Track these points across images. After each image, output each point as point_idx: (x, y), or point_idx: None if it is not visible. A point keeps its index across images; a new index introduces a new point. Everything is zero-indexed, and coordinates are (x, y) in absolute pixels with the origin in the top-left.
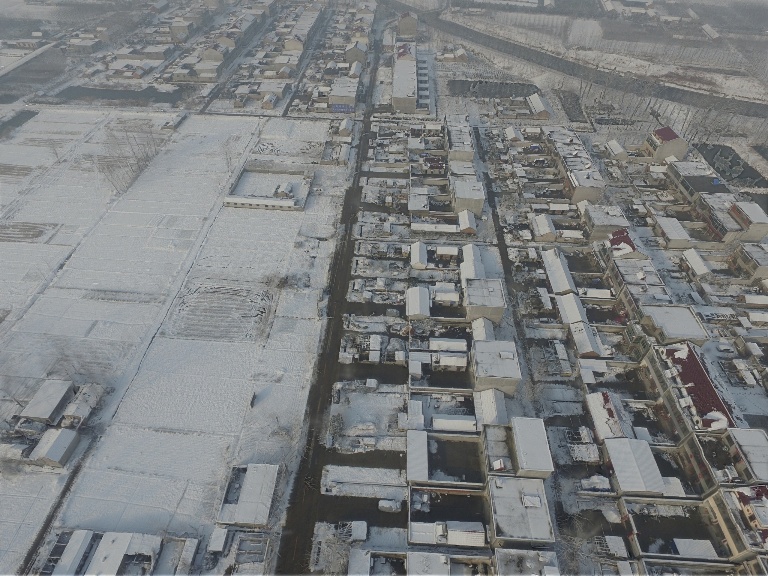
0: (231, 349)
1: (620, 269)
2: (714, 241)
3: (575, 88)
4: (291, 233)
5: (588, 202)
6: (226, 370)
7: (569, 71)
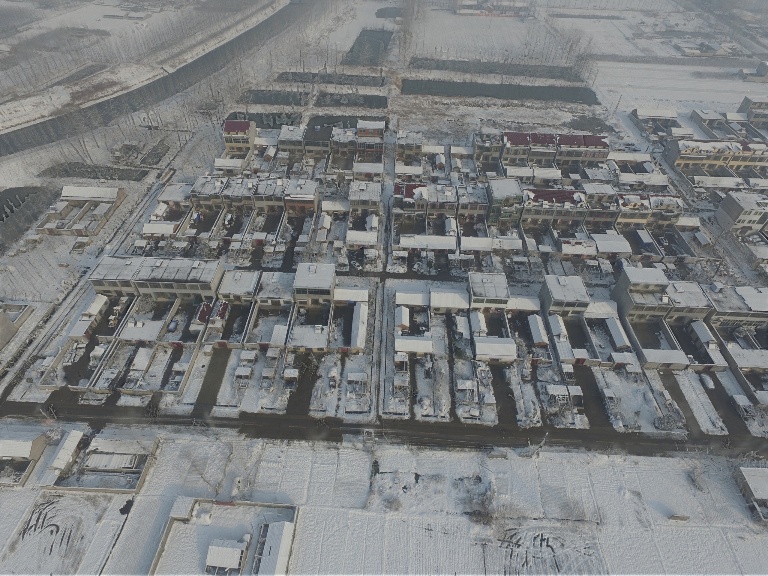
0: (620, 573)
1: (441, 201)
2: (376, 157)
3: (54, 159)
4: (360, 523)
5: (326, 201)
6: (654, 570)
7: (10, 150)
